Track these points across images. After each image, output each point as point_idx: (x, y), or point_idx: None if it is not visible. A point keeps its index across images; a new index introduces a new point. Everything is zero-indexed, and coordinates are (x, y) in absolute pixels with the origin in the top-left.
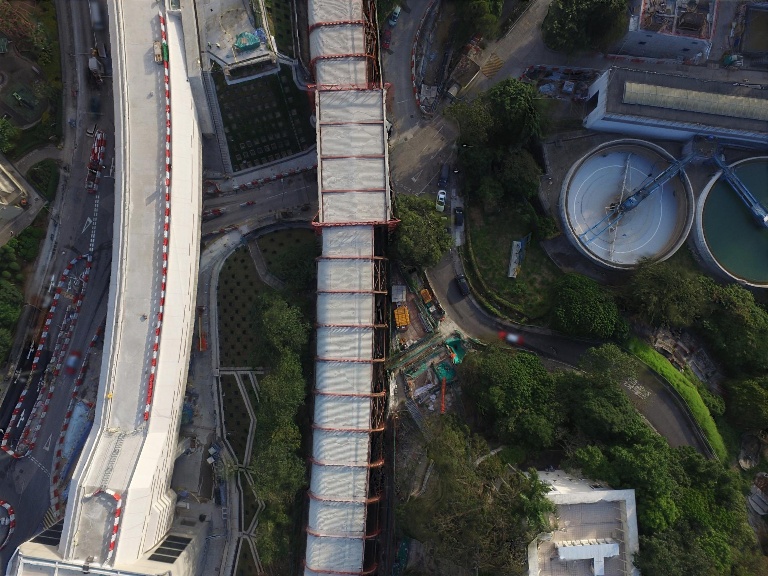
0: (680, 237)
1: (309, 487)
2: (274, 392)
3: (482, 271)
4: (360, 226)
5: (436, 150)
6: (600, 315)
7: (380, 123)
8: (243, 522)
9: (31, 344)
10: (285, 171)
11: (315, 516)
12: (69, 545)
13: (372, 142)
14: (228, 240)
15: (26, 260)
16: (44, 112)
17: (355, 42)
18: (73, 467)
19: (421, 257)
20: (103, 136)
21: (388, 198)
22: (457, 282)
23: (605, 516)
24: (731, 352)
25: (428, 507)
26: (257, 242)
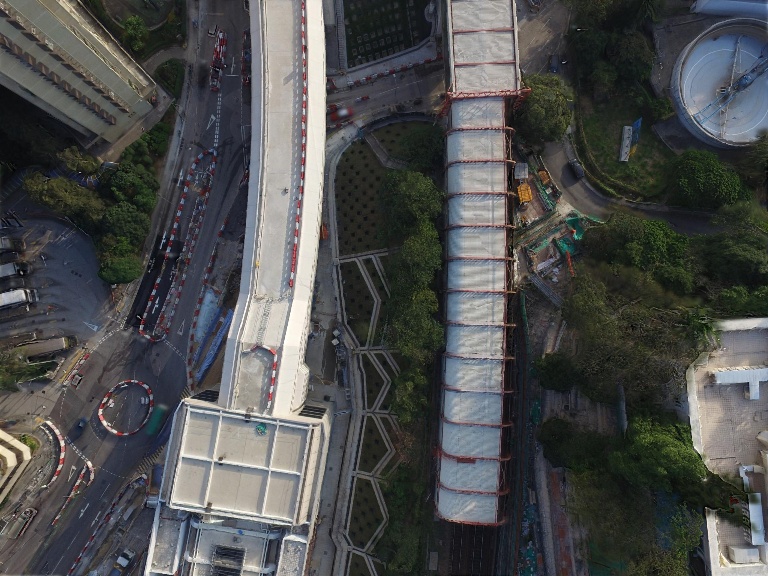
0: None
1: (445, 350)
2: (417, 253)
3: (593, 156)
4: (491, 98)
5: (543, 42)
6: (724, 182)
7: None
8: (366, 401)
9: (163, 235)
10: (397, 66)
11: (454, 374)
12: (231, 396)
13: (500, 17)
14: (344, 134)
15: (158, 154)
16: (170, 13)
17: None
18: (204, 352)
19: (549, 128)
20: (225, 35)
21: (518, 69)
22: (571, 166)
23: (757, 346)
24: None
25: (568, 359)
26: (373, 134)
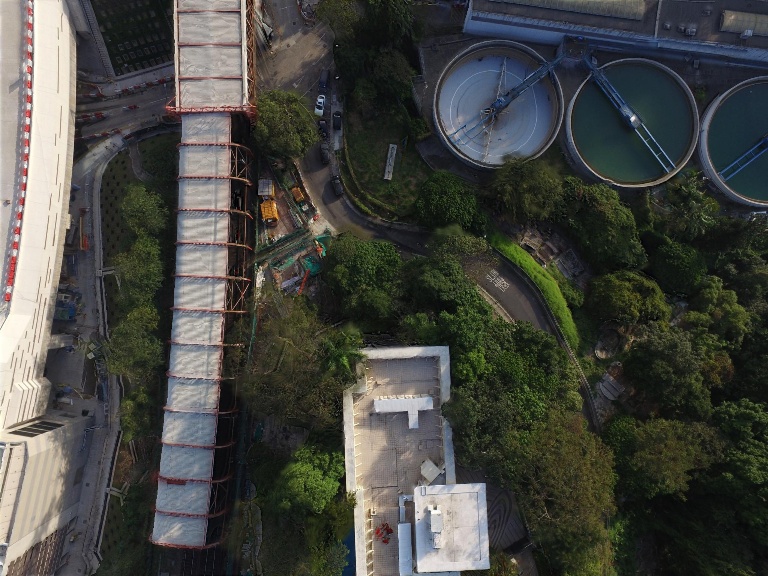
0: (550, 138)
1: (168, 368)
2: (126, 270)
3: (358, 174)
4: (217, 113)
5: (318, 57)
6: (457, 205)
7: (237, 11)
8: None
9: None
10: (168, 76)
11: (170, 393)
12: None
13: (231, 31)
14: (111, 143)
15: None
16: None
17: None
18: None
19: (279, 146)
20: None
21: (244, 85)
22: (332, 183)
23: (424, 374)
24: (594, 249)
25: (274, 381)
26: (138, 144)
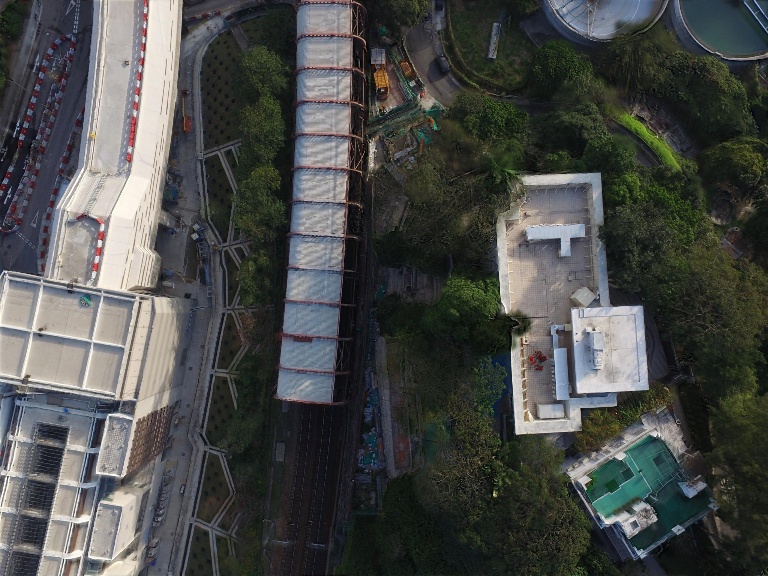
0: (657, 13)
1: (289, 231)
2: (253, 123)
3: (462, 53)
4: None
5: None
6: (575, 68)
7: None
8: (227, 299)
9: (17, 122)
10: None
11: (294, 253)
12: (53, 265)
13: None
14: (211, 25)
15: (10, 36)
16: None
17: None
18: None
19: (399, 6)
20: None
21: None
22: (437, 60)
23: (573, 205)
24: (705, 120)
25: (404, 233)
26: (239, 25)
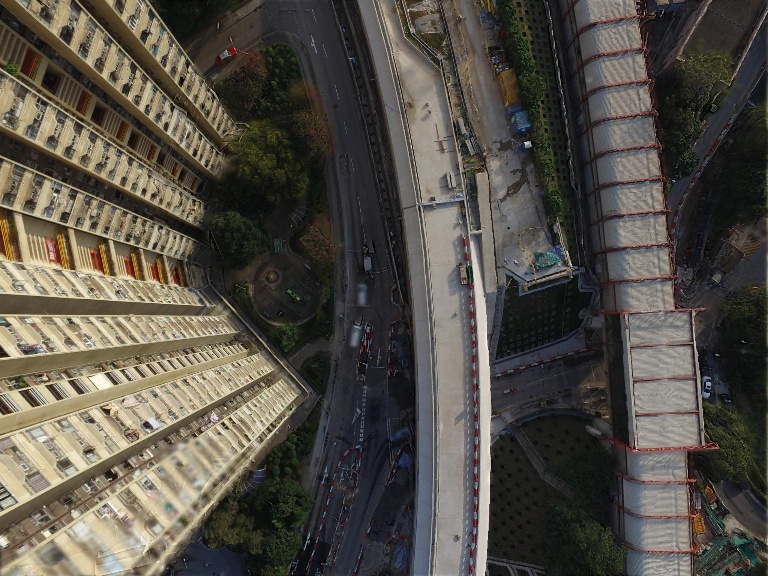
0: None
1: None
2: None
3: (755, 461)
4: None
5: (695, 333)
6: None
7: (690, 344)
8: None
9: (307, 536)
10: (545, 357)
11: None
12: None
13: (679, 361)
14: (492, 428)
15: (305, 455)
16: (318, 308)
17: (661, 263)
18: None
19: None
20: (372, 329)
21: (702, 420)
22: None
23: None
24: None
25: None
26: (523, 431)
